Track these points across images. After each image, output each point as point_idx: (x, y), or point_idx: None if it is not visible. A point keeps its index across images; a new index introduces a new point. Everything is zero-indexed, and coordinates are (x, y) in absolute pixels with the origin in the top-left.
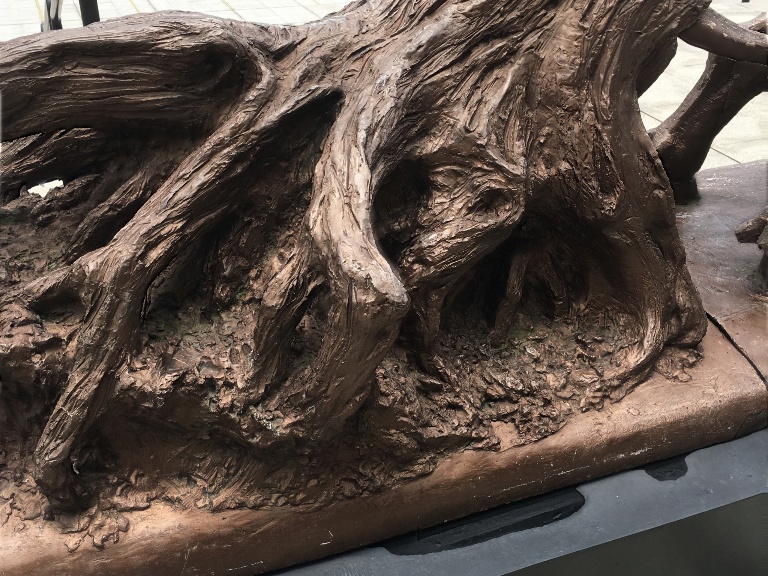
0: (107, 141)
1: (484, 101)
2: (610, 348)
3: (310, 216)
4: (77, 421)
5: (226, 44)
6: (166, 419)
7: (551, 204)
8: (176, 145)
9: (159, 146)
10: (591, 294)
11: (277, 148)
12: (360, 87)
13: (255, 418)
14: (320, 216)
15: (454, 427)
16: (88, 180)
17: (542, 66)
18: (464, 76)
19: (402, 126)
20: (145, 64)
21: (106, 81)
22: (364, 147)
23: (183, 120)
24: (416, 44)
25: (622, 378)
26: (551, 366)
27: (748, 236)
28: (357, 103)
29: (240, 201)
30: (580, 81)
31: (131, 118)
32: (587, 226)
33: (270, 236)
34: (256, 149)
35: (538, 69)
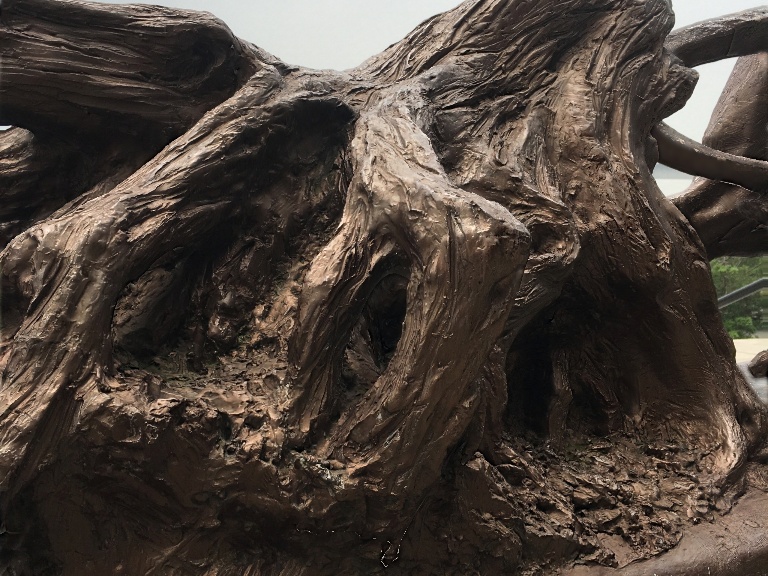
0: (41, 177)
1: (505, 145)
2: (689, 457)
3: (362, 174)
4: (7, 464)
5: (221, 29)
6: (155, 476)
7: (592, 270)
8: (146, 159)
9: (123, 160)
10: (644, 401)
11: (284, 154)
12: (374, 104)
13: (302, 465)
14: (376, 173)
15: (556, 527)
16: (10, 223)
17: (556, 120)
18: (480, 118)
19: (434, 135)
20: (117, 43)
21: (66, 51)
22: (411, 119)
23: (160, 120)
24: (428, 74)
25: (720, 486)
26: (633, 475)
27: (765, 367)
28: (380, 105)
29: (243, 206)
30: (599, 133)
31: (93, 107)
32: (637, 294)
33: (277, 267)
34: (268, 131)
35: (552, 123)
